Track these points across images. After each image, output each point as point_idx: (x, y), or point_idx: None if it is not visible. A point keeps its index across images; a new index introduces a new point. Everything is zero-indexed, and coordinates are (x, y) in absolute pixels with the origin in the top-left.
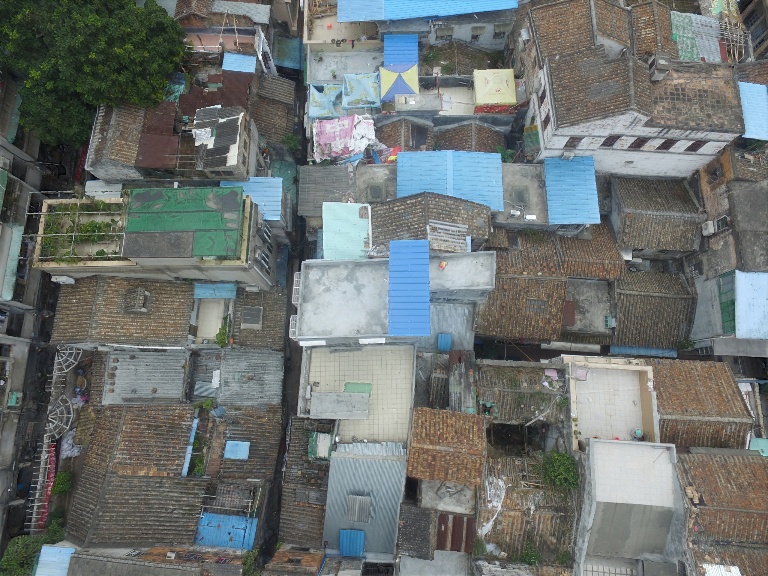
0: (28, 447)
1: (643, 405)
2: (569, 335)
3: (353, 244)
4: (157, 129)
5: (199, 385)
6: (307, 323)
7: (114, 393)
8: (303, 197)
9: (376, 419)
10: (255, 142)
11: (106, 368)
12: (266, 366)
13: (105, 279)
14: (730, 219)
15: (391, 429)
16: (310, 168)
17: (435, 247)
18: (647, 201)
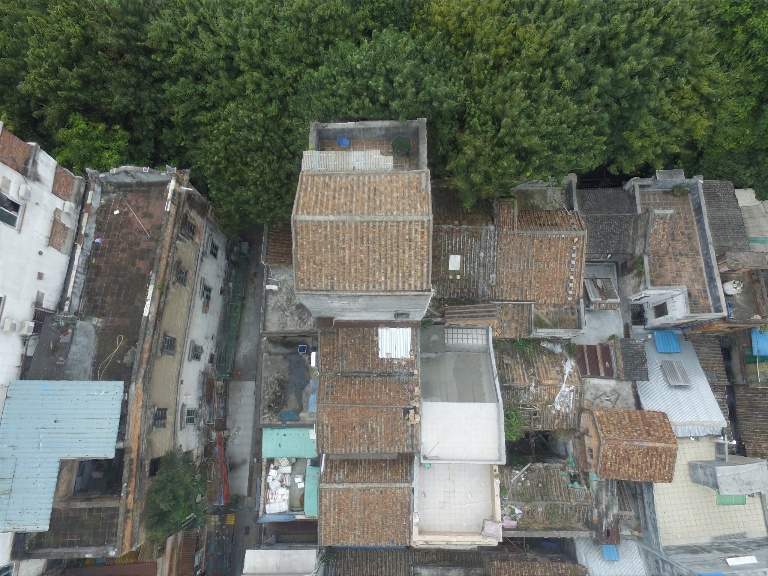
0: None
1: None
2: (460, 562)
3: None
4: None
5: None
6: None
7: None
8: None
9: (679, 460)
10: None
11: None
12: None
13: None
14: None
15: None
16: None
17: None
18: None
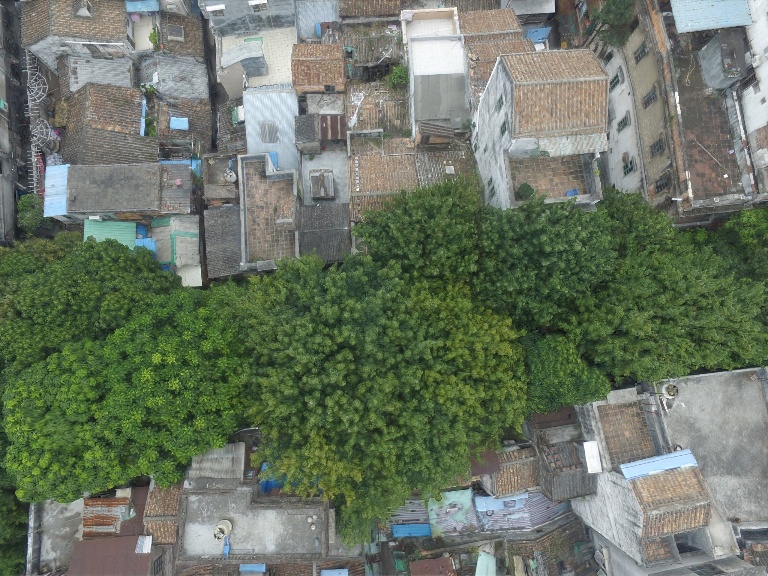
0: (20, 166)
1: None
2: None
3: None
4: None
5: None
6: None
7: (78, 84)
8: None
9: (274, 76)
10: None
11: (69, 67)
12: (193, 72)
13: None
14: None
15: (285, 81)
16: None
17: None
18: None
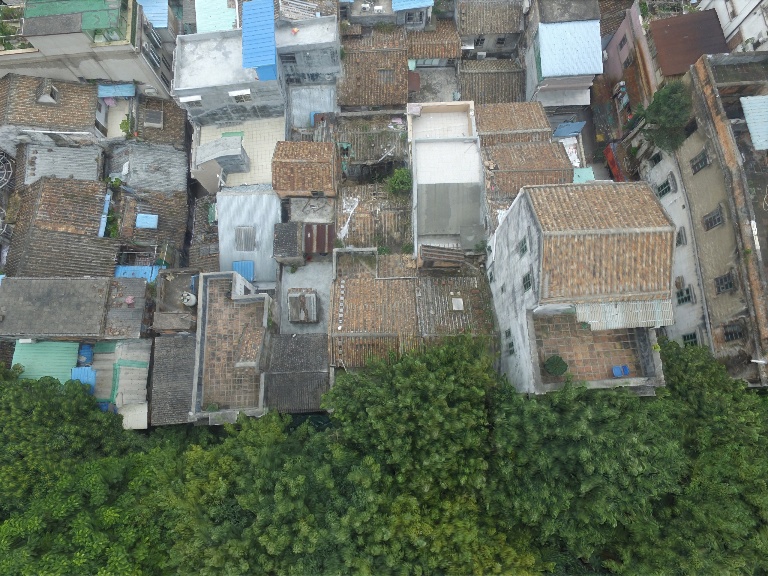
0: None
1: (469, 134)
2: None
3: (223, 27)
4: None
5: (112, 176)
6: (184, 83)
7: (35, 176)
8: (186, 9)
9: (257, 173)
10: None
11: (27, 157)
12: (171, 161)
13: (17, 77)
14: None
15: (269, 179)
16: None
17: (287, 16)
18: None
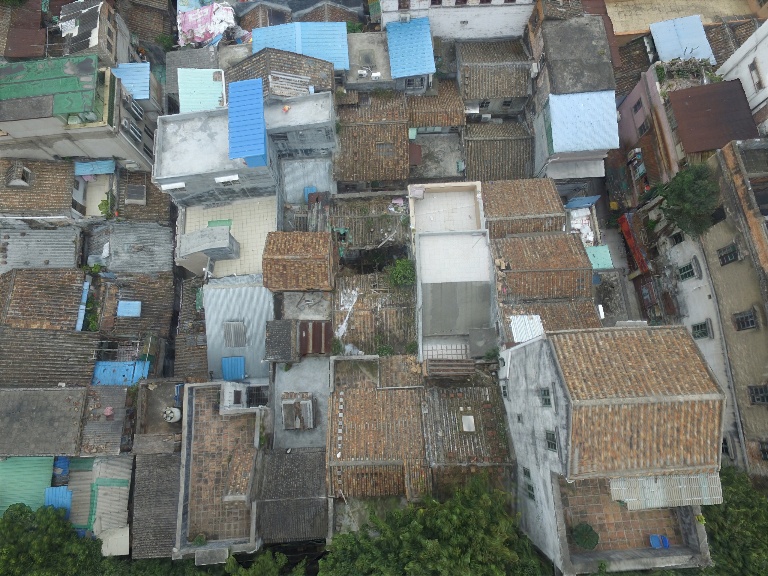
0: None
1: (477, 217)
2: (426, 182)
3: (208, 103)
4: (25, 24)
5: (91, 258)
6: (166, 169)
7: (7, 265)
8: (170, 78)
9: (247, 259)
10: (125, 37)
11: None
12: (155, 239)
13: None
14: (545, 54)
15: (261, 266)
16: (175, 53)
17: (277, 93)
18: (484, 56)
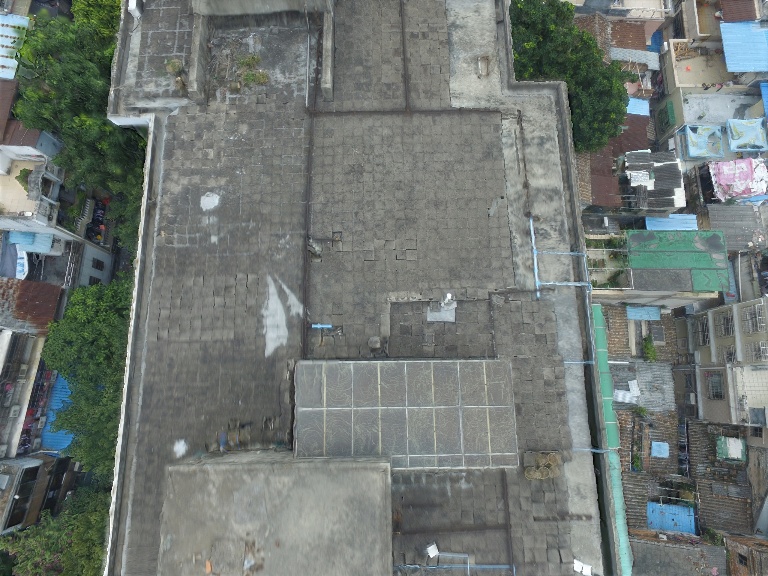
0: None
1: None
2: None
3: None
4: (600, 170)
5: (617, 393)
6: None
7: None
8: None
9: None
10: None
11: None
12: (663, 377)
13: None
14: None
15: None
16: (717, 206)
17: None
18: None
